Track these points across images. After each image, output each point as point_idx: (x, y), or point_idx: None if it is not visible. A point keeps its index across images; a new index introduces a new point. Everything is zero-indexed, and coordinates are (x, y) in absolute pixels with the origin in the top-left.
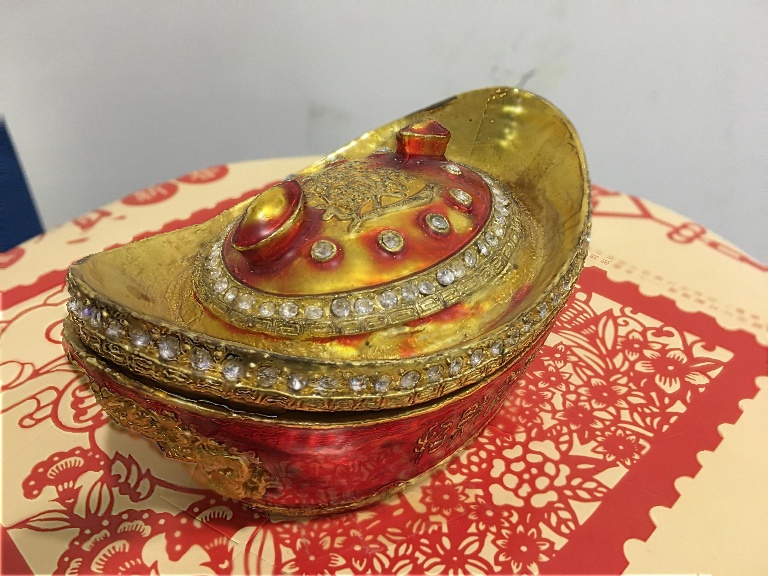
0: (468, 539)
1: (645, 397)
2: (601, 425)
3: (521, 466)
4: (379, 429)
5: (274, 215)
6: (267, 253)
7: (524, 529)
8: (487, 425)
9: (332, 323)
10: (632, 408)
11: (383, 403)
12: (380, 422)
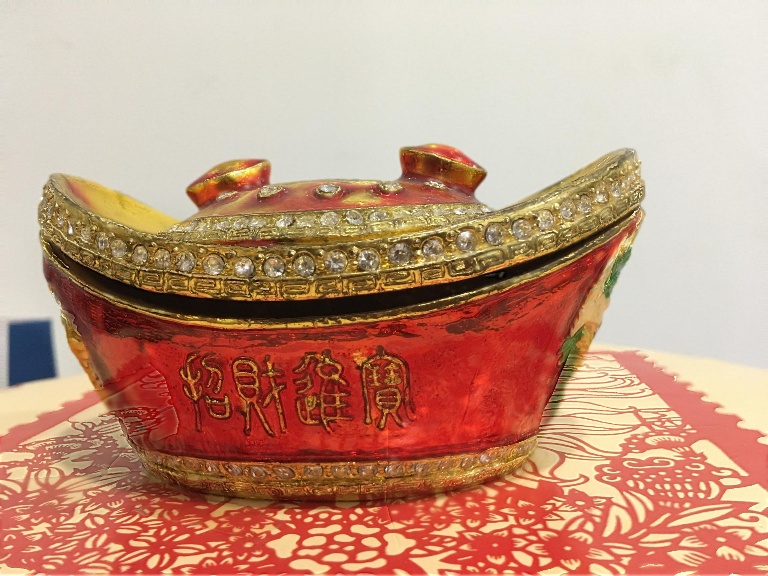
0: (197, 545)
1: (621, 574)
2: (500, 561)
3: (346, 539)
4: (131, 319)
5: (222, 172)
6: (203, 198)
7: (244, 568)
8: (385, 505)
9: (172, 233)
10: (577, 572)
11: (114, 270)
12: (129, 308)
